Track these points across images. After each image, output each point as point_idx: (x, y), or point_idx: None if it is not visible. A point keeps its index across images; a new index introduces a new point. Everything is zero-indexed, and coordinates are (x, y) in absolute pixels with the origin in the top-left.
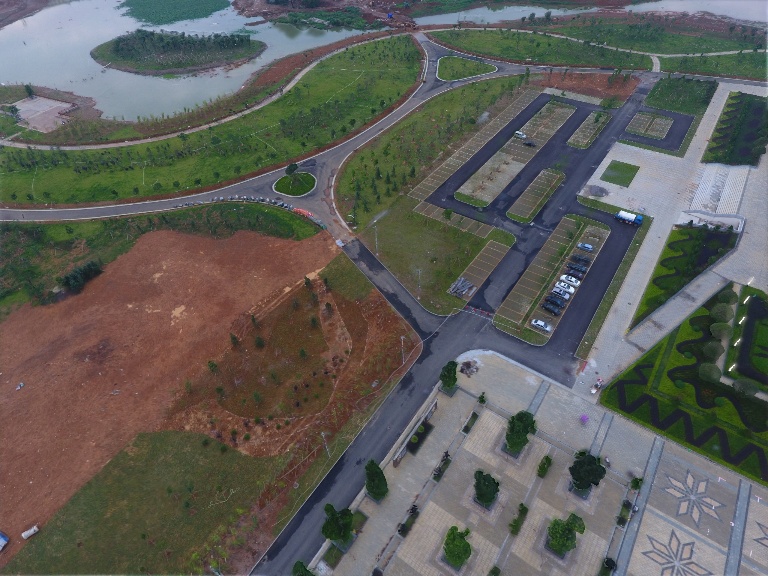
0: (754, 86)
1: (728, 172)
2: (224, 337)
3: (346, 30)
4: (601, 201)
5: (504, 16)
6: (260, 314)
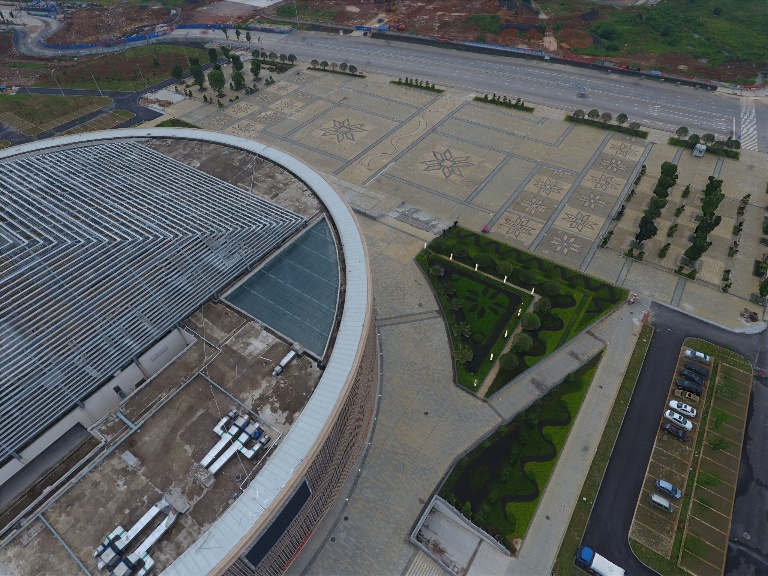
0: None
1: None
2: None
3: None
4: None
5: None
6: None
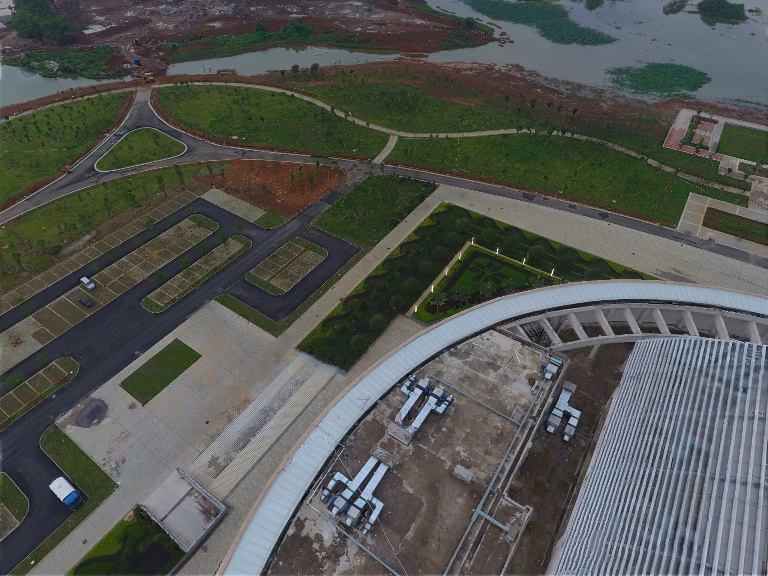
0: (479, 193)
1: (309, 376)
2: None
3: (83, 78)
4: (74, 440)
5: (280, 64)
6: None
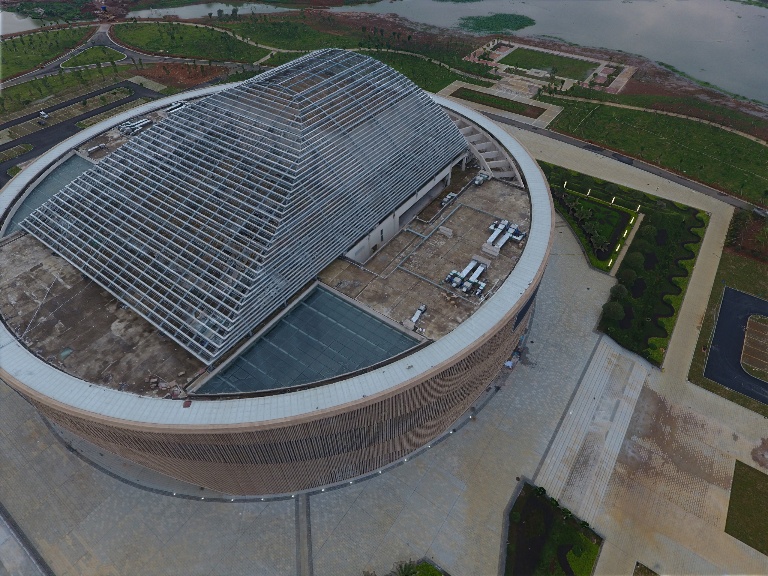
0: None
1: None
2: None
3: (63, 20)
4: None
5: (214, 12)
6: None
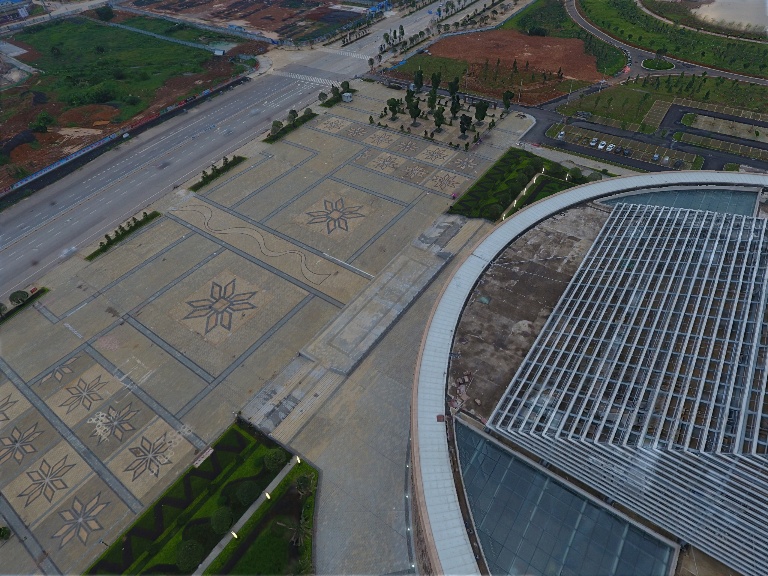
0: None
1: None
2: (517, 65)
3: None
4: None
5: None
6: (535, 70)
